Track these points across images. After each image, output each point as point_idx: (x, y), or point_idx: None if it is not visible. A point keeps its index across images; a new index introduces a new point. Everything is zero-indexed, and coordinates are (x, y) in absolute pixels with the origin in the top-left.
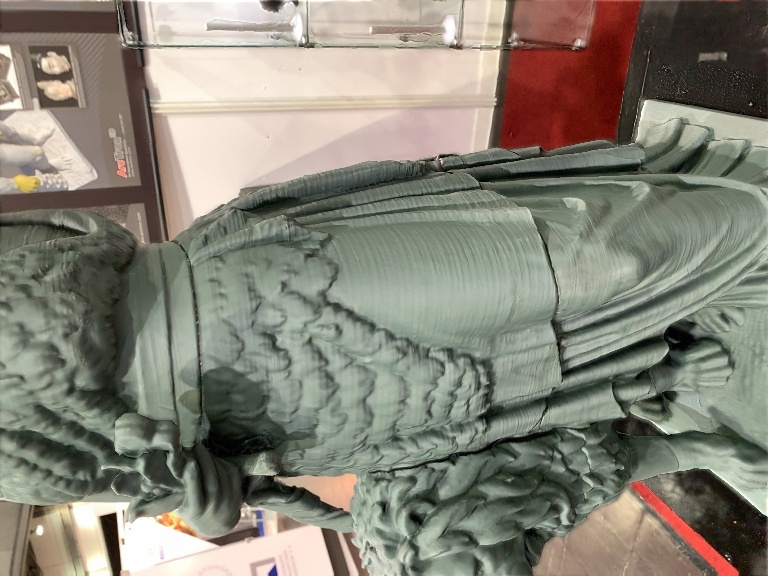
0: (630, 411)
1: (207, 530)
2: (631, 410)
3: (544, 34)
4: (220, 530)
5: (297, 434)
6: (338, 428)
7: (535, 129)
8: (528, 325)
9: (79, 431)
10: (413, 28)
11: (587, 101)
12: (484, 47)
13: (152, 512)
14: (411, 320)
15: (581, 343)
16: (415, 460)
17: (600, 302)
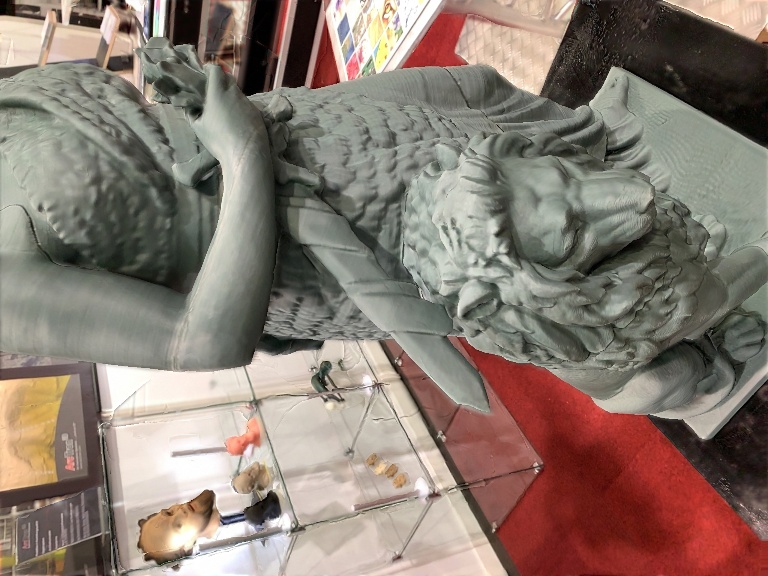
0: (735, 354)
1: (236, 130)
2: (733, 350)
3: (514, 499)
4: (250, 132)
5: (303, 124)
6: (337, 120)
7: (568, 573)
8: (448, 98)
9: (109, 111)
10: (390, 498)
11: (580, 495)
12: (458, 486)
13: (178, 71)
14: (357, 86)
15: (512, 129)
16: (429, 152)
17: (481, 77)
